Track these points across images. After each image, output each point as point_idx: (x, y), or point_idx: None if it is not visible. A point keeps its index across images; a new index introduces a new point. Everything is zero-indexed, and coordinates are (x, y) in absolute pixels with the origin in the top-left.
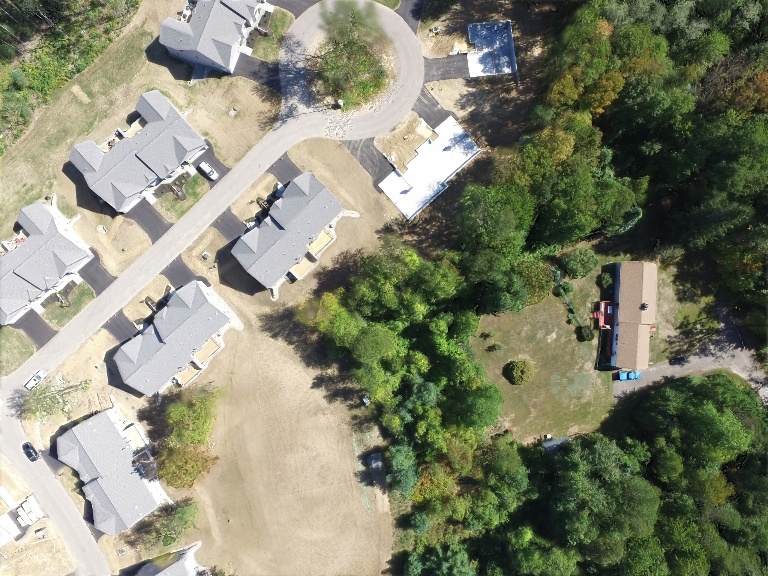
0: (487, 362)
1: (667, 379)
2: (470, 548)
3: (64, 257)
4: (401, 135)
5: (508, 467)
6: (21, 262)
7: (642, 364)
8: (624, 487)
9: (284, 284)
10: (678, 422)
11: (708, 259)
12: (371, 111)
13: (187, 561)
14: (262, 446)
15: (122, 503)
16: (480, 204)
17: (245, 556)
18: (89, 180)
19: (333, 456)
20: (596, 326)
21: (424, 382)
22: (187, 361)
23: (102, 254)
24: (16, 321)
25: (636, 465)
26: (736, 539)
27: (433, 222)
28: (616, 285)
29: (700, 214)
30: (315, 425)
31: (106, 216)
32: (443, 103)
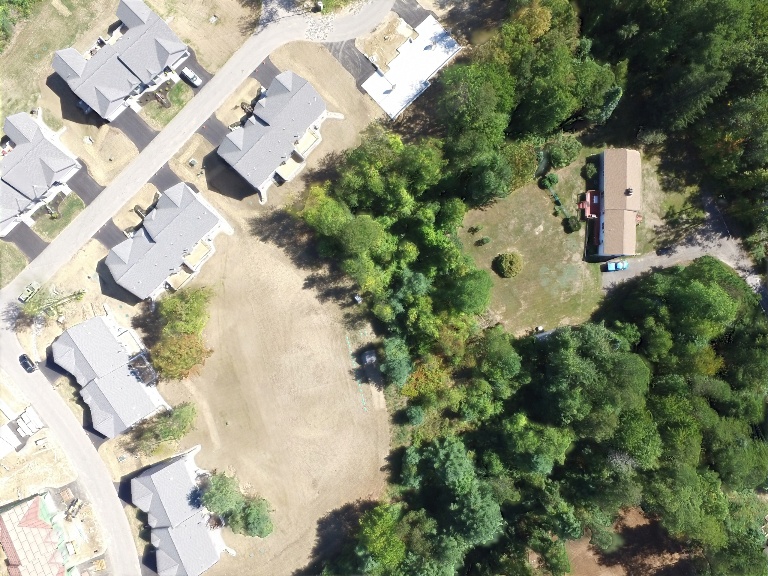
0: (476, 257)
1: (655, 269)
2: (467, 440)
3: (51, 164)
4: (382, 36)
5: (500, 352)
6: (9, 169)
7: (629, 250)
8: (615, 362)
9: (272, 187)
10: (666, 302)
11: (691, 148)
12: (351, 13)
13: (187, 463)
14: (257, 347)
15: (120, 403)
16: (460, 81)
17: (245, 458)
18: (73, 85)
19: (327, 355)
20: (583, 217)
21: (414, 274)
22: (178, 263)
23: (89, 164)
24: (7, 234)
25: (626, 344)
26: (727, 410)
27: (417, 120)
28: (601, 175)
29: (679, 90)
30: (308, 325)
31: (92, 126)
32: (422, 3)
